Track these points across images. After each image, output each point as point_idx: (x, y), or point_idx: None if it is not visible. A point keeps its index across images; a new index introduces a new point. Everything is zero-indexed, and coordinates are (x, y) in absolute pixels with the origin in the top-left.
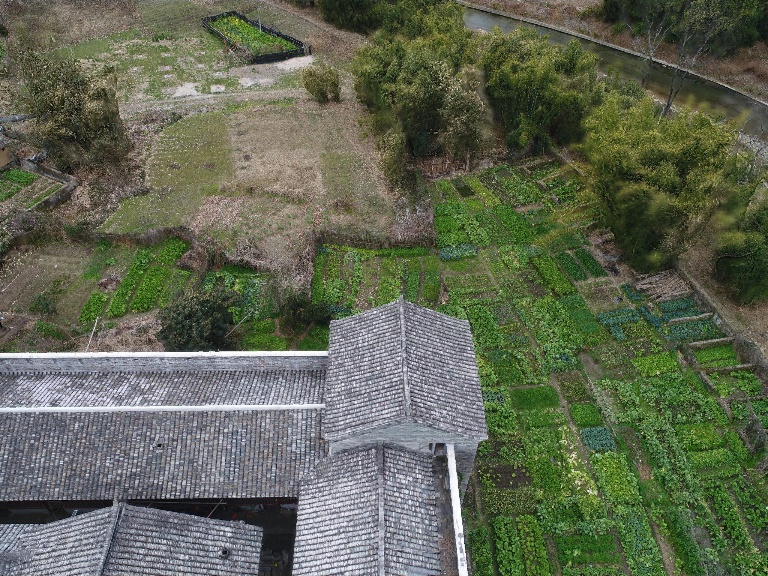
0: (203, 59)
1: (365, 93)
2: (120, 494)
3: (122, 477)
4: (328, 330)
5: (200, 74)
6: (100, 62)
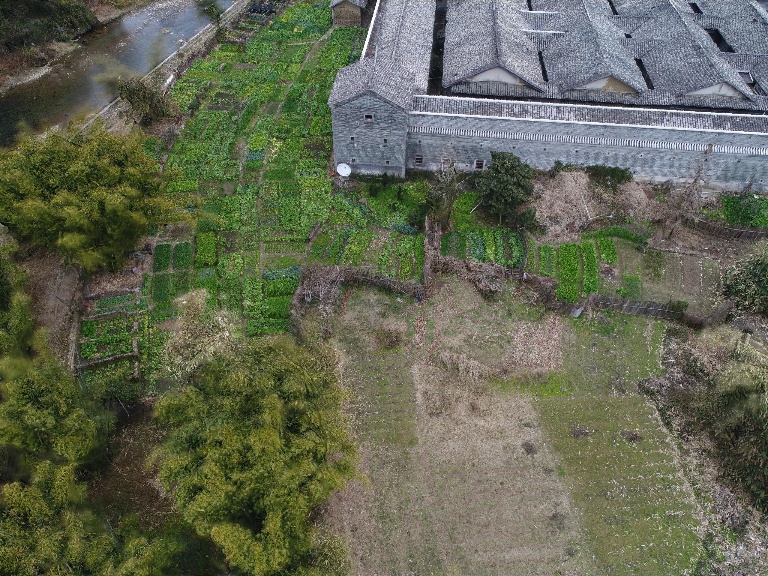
0: None
1: None
2: None
3: None
4: None
5: None
6: None
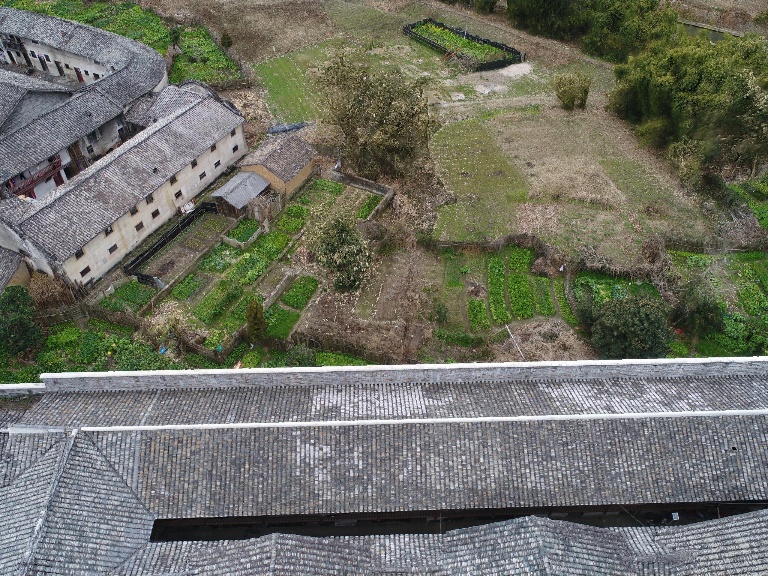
0: (425, 67)
1: (622, 100)
2: (710, 496)
3: (705, 480)
4: (718, 334)
5: (432, 82)
6: None
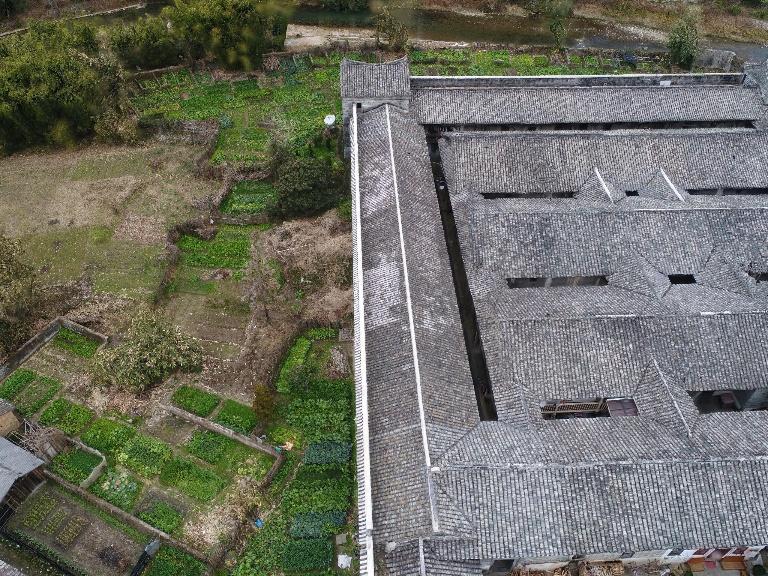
0: None
1: None
2: (431, 173)
3: None
4: None
5: None
6: None
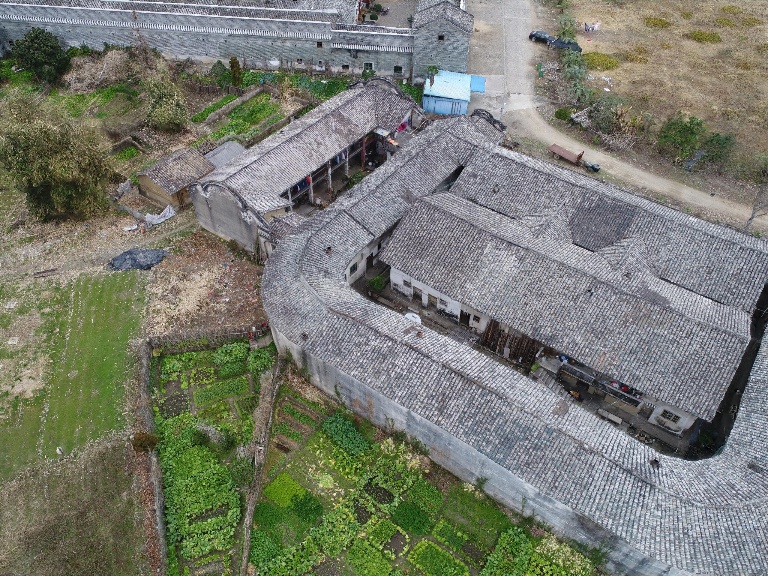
0: None
1: None
2: None
3: None
4: None
5: None
6: (4, 392)
